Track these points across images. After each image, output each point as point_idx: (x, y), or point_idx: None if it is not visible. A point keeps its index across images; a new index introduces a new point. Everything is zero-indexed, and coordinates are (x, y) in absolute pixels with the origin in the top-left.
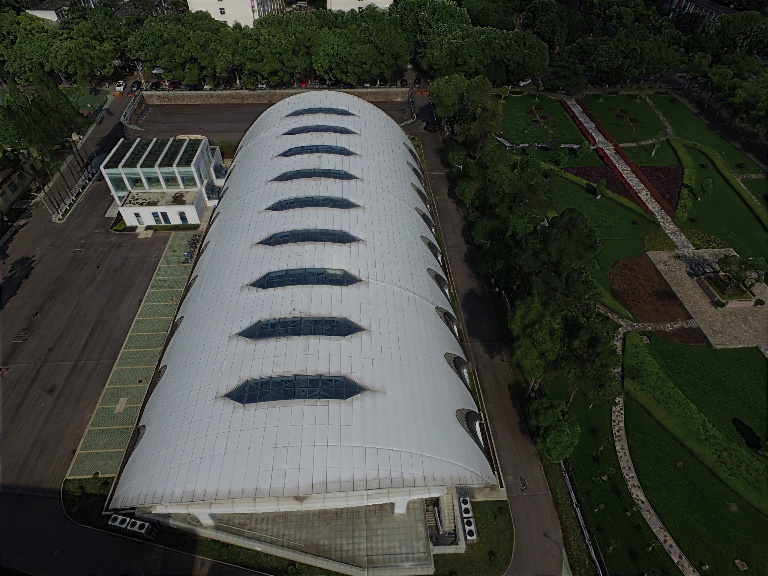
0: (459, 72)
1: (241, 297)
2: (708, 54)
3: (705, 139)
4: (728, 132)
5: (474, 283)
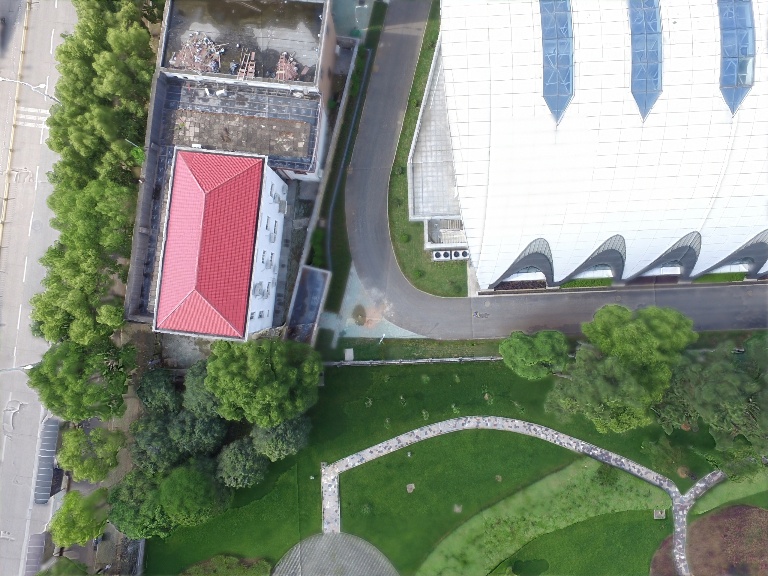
0: None
1: None
2: None
3: None
4: None
5: (763, 314)
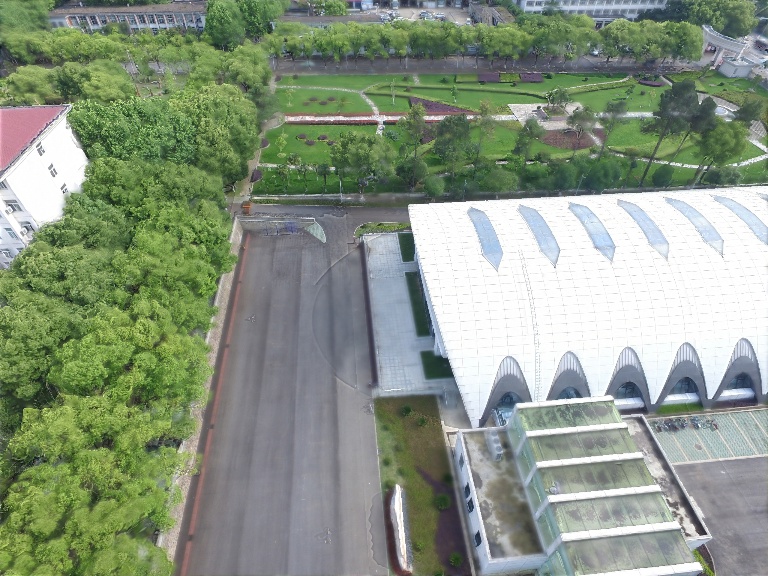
0: (252, 156)
1: None
2: (274, 33)
3: (364, 82)
4: (354, 72)
5: None
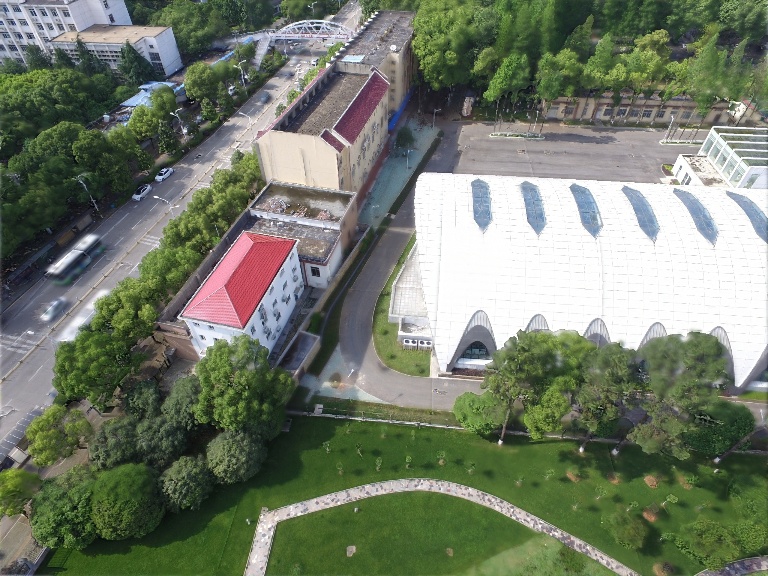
0: None
1: (562, 182)
2: None
3: None
4: None
5: None
